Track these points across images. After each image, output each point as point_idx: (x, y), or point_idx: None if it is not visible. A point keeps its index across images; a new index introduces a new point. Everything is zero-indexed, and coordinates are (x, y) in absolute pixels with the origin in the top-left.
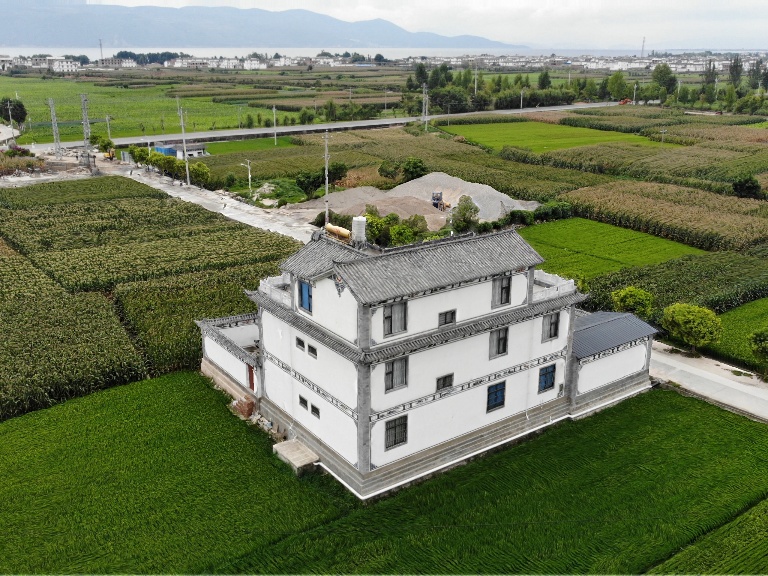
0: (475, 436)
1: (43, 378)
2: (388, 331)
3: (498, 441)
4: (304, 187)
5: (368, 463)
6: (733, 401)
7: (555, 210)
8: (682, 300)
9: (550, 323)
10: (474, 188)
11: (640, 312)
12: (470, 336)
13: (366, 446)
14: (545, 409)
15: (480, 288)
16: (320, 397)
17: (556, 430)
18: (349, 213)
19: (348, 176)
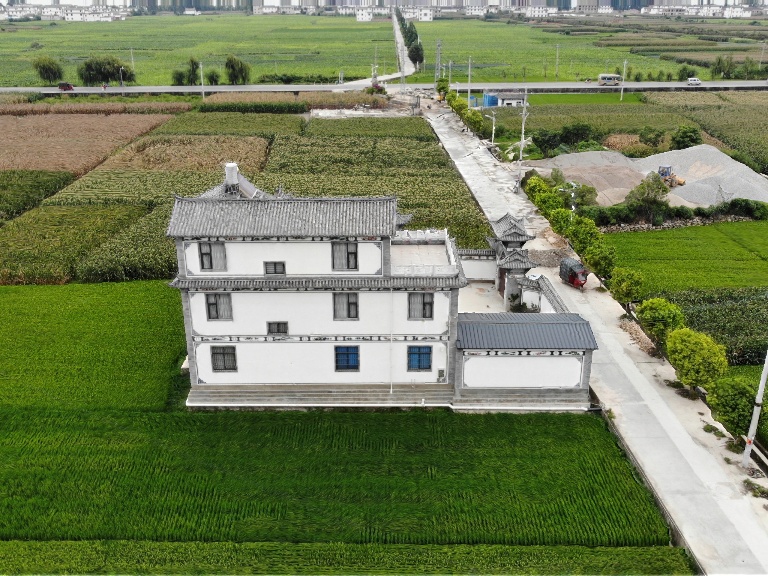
0: (321, 389)
1: (127, 260)
2: (209, 266)
3: (349, 402)
4: (538, 145)
5: (195, 377)
6: (645, 452)
7: None
8: None
9: (423, 302)
10: (732, 168)
11: (658, 330)
12: (306, 291)
13: (192, 361)
14: (418, 390)
15: (315, 247)
16: None
17: (422, 413)
18: None
19: (626, 139)
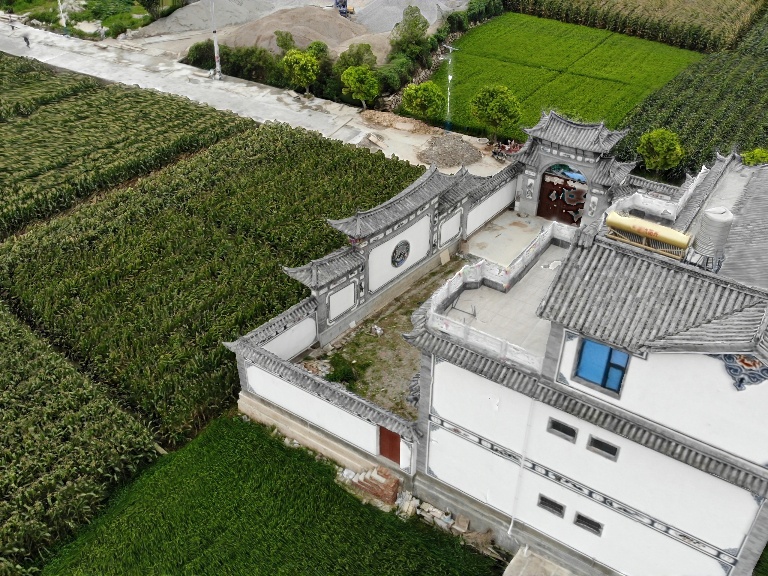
0: None
1: None
2: None
3: None
4: (146, 2)
5: None
6: None
7: (488, 6)
8: (761, 142)
9: None
10: None
11: None
12: None
13: None
14: None
15: None
16: (611, 511)
17: None
18: (239, 42)
19: None
